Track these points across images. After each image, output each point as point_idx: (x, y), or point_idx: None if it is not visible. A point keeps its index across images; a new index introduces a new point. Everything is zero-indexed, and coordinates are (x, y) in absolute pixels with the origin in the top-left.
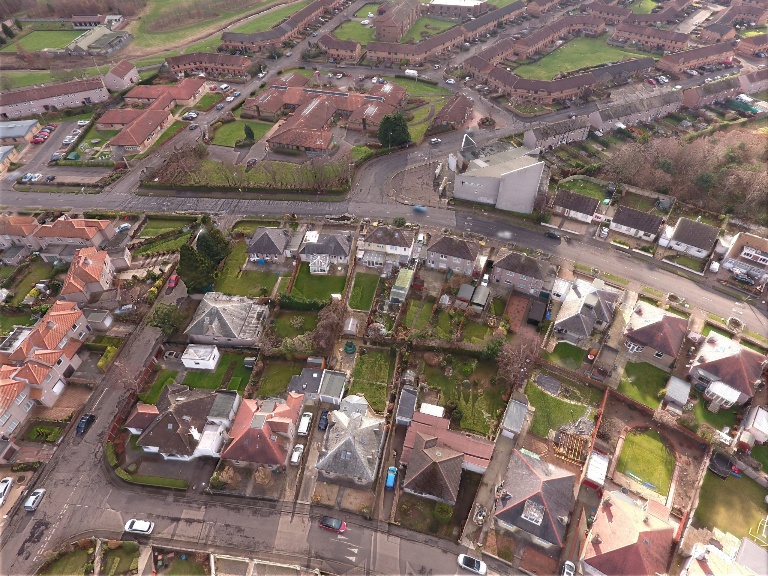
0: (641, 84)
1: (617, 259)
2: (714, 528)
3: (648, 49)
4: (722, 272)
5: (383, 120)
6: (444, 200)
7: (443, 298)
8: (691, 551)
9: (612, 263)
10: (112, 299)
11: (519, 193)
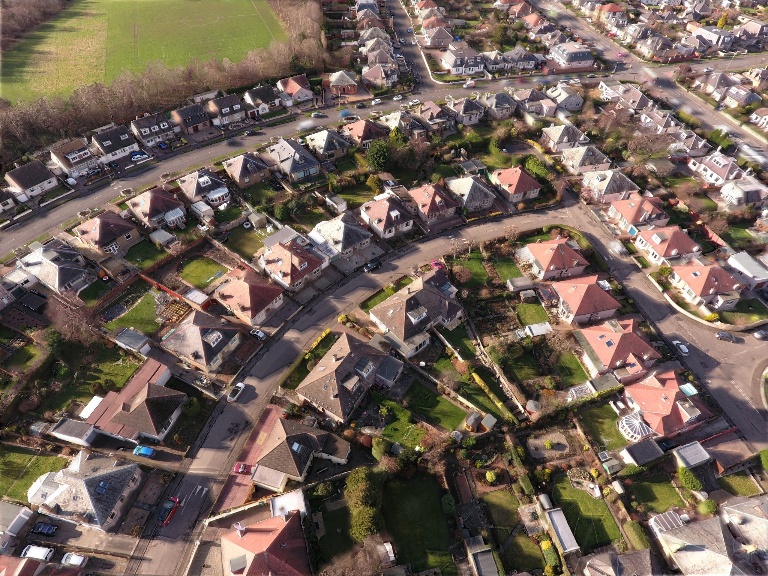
0: None
1: (16, 233)
2: (253, 255)
3: None
4: (79, 180)
5: None
6: None
7: None
8: (262, 268)
9: (18, 237)
10: None
11: None
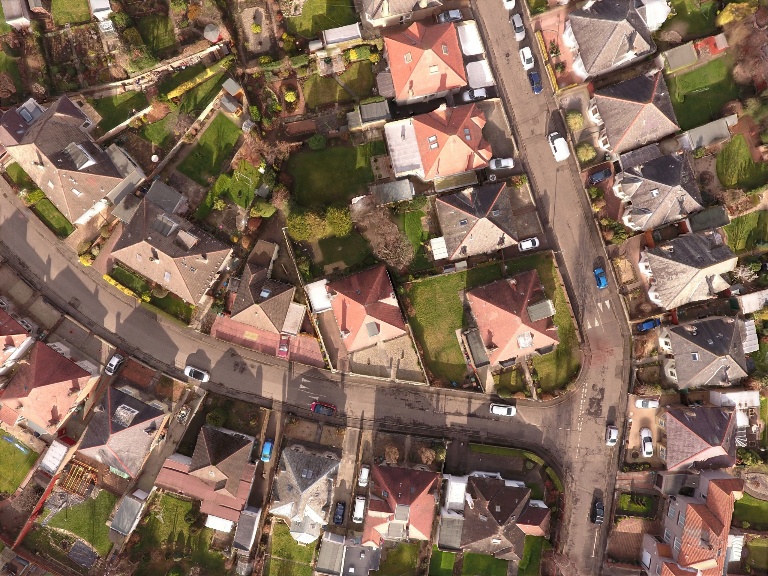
0: None
1: None
2: None
3: None
4: None
5: None
6: None
7: None
8: None
9: None
10: None
11: None
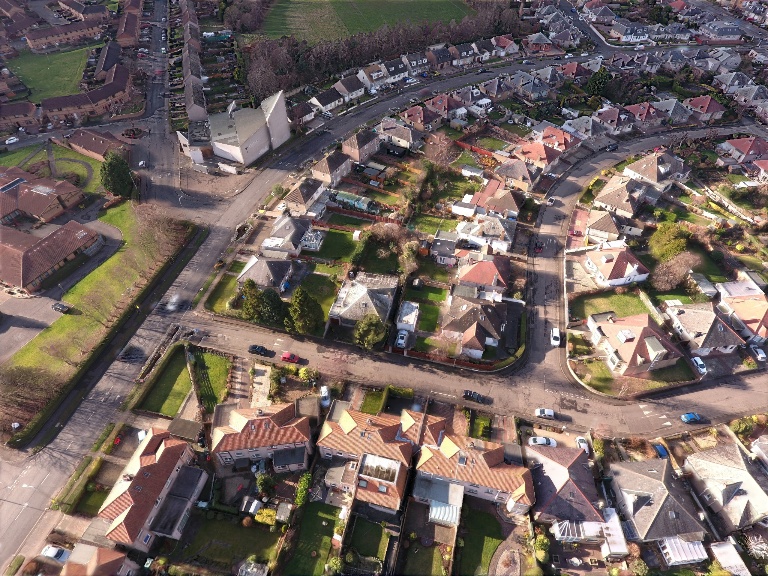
0: (140, 60)
1: (354, 118)
2: None
3: (81, 42)
4: None
5: (108, 168)
6: (249, 171)
7: (374, 182)
8: None
9: (357, 120)
10: (315, 401)
11: (280, 126)
